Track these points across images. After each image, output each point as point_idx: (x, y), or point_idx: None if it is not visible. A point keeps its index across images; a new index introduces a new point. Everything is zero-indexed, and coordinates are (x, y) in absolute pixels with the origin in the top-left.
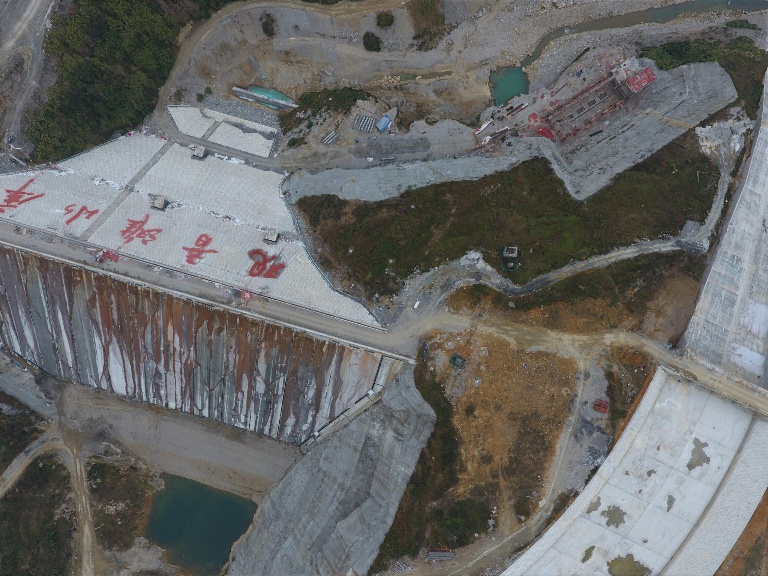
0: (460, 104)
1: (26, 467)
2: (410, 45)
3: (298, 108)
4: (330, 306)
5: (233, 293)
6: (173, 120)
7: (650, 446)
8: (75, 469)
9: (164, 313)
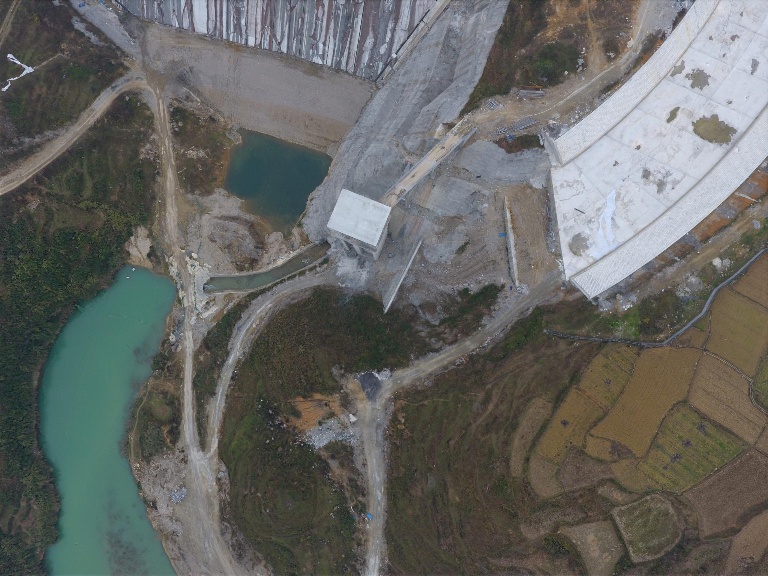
0: None
1: (113, 100)
2: None
3: None
4: None
5: None
6: None
7: (733, 12)
8: (158, 110)
9: None
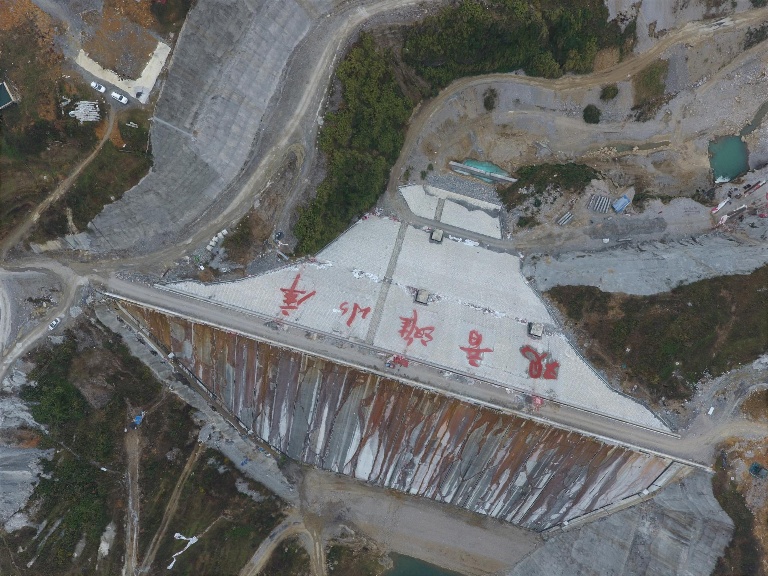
0: (679, 176)
1: (272, 552)
2: (628, 116)
3: (520, 184)
4: (616, 410)
5: (524, 399)
6: (405, 201)
7: None
8: (314, 552)
9: (443, 414)
